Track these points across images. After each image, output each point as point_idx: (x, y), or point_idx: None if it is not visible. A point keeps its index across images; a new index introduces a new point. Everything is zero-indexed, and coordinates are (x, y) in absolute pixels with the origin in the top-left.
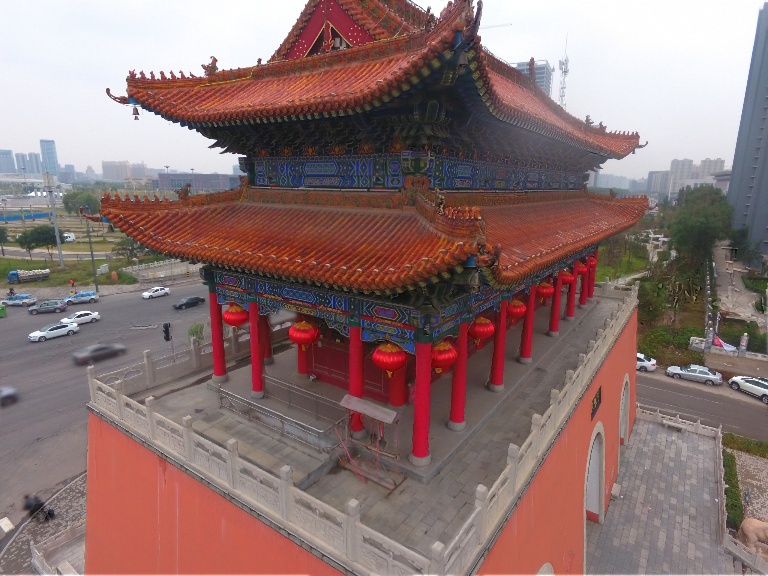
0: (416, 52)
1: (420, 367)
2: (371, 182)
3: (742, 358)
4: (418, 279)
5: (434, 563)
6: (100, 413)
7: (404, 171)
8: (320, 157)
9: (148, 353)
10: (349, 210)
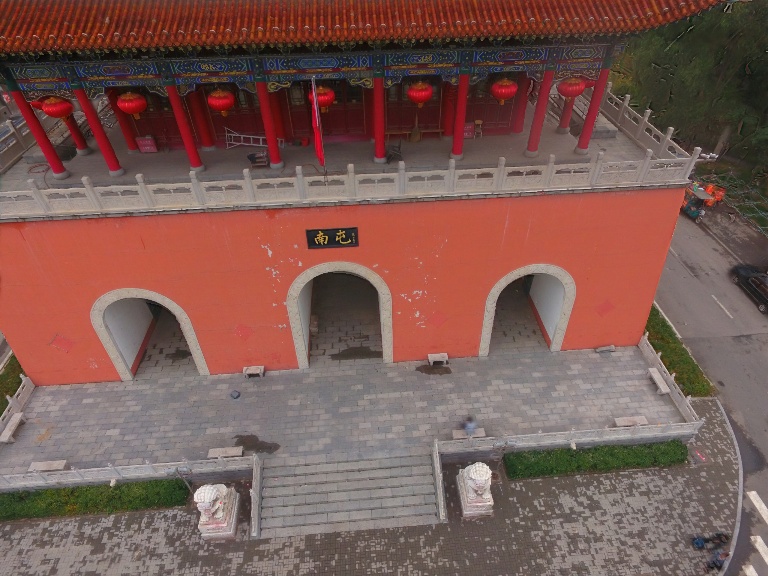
0: None
1: None
2: None
3: None
4: None
5: None
6: None
7: None
8: None
9: None
10: None
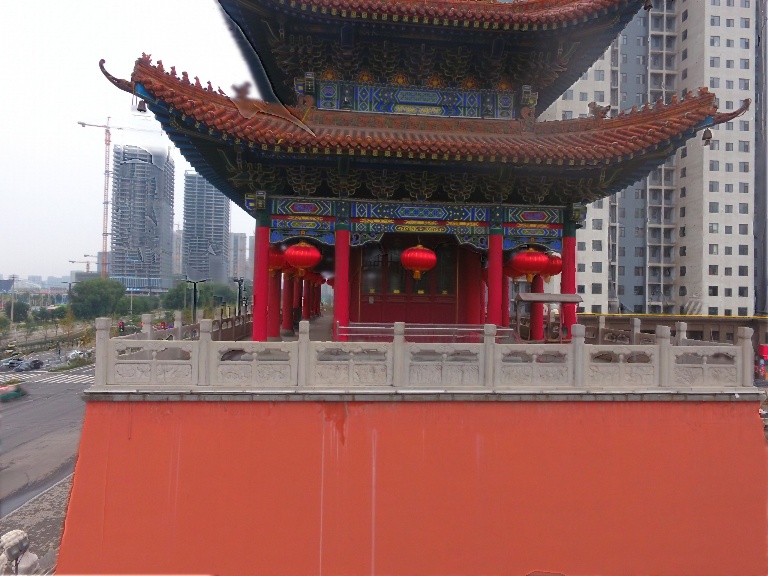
0: (535, 12)
1: (572, 259)
2: (479, 113)
3: None
4: (657, 141)
5: (749, 341)
6: (141, 391)
7: (521, 103)
8: (418, 87)
9: (152, 317)
10: (463, 134)
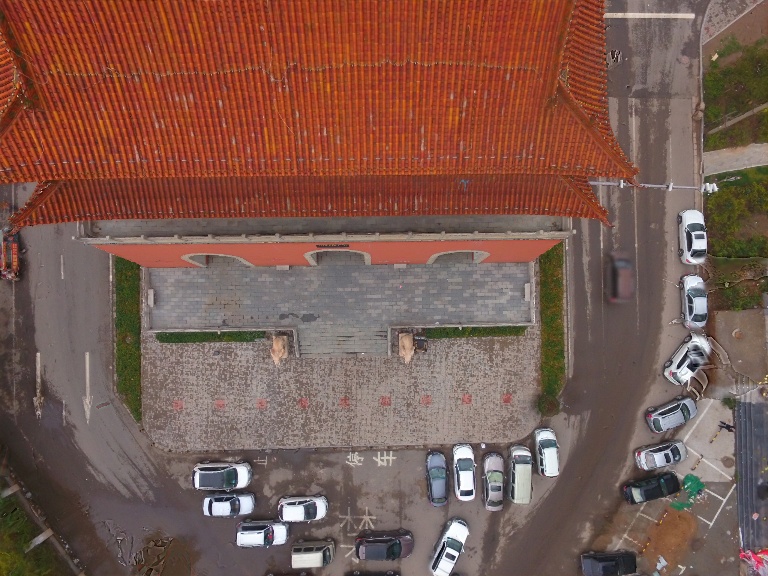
0: None
1: None
2: None
3: (764, 347)
4: None
5: None
6: None
7: None
8: None
9: None
10: None
